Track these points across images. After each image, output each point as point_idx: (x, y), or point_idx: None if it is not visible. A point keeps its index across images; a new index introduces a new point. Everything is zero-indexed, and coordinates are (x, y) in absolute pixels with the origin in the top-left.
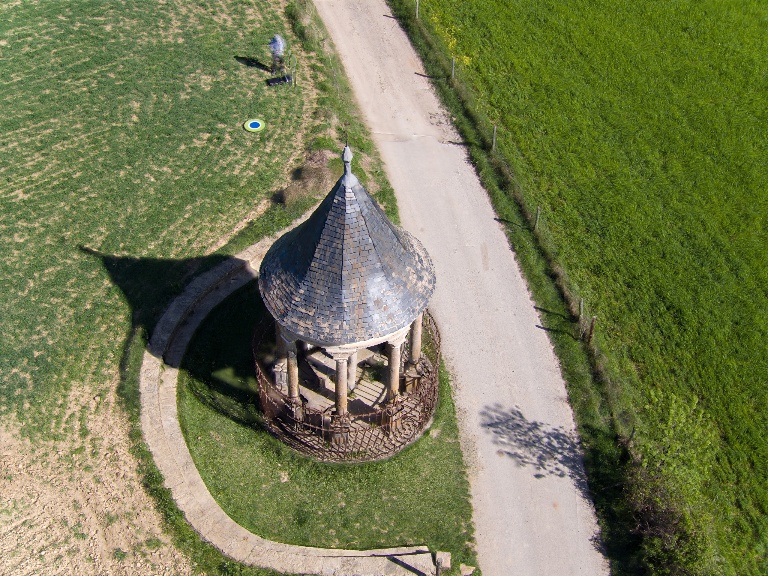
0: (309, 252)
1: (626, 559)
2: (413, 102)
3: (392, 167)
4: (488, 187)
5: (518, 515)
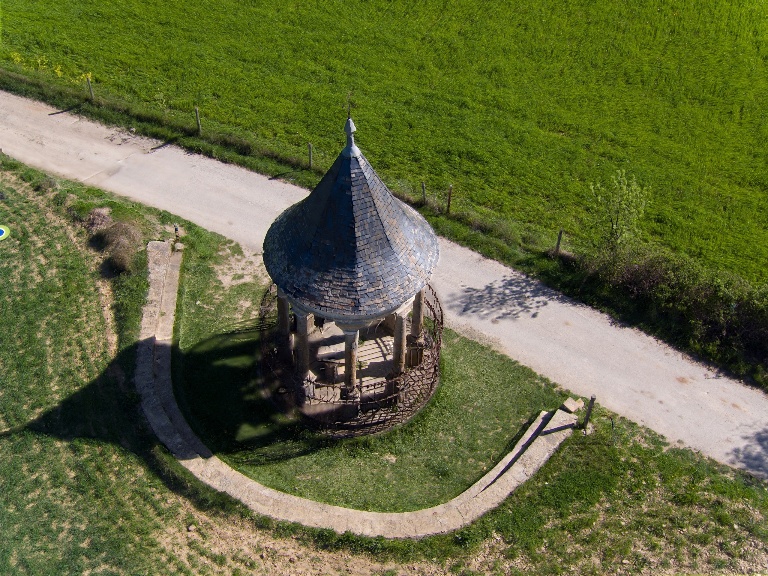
0: (346, 238)
1: (647, 317)
2: (80, 138)
3: (139, 196)
4: (234, 161)
5: (557, 348)
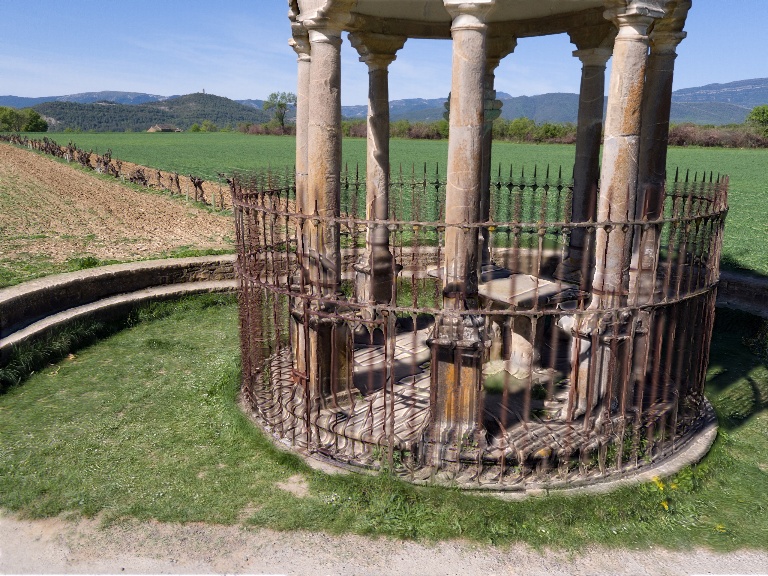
0: None
1: None
2: None
3: None
4: None
5: None
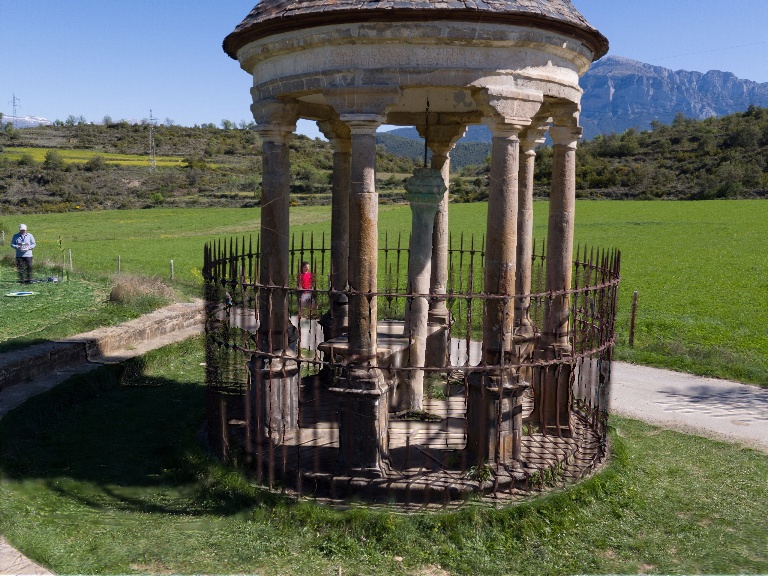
0: None
1: None
2: None
3: None
4: None
5: None
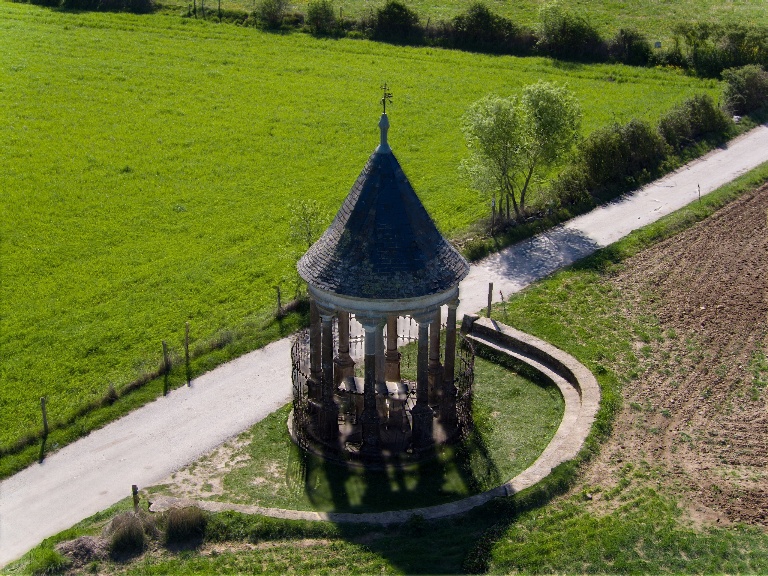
0: (425, 218)
1: None
2: None
3: None
4: None
5: None
